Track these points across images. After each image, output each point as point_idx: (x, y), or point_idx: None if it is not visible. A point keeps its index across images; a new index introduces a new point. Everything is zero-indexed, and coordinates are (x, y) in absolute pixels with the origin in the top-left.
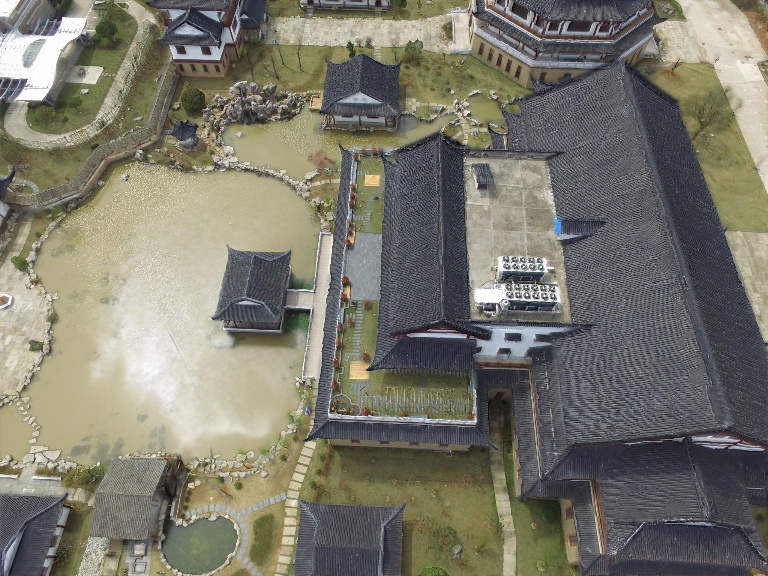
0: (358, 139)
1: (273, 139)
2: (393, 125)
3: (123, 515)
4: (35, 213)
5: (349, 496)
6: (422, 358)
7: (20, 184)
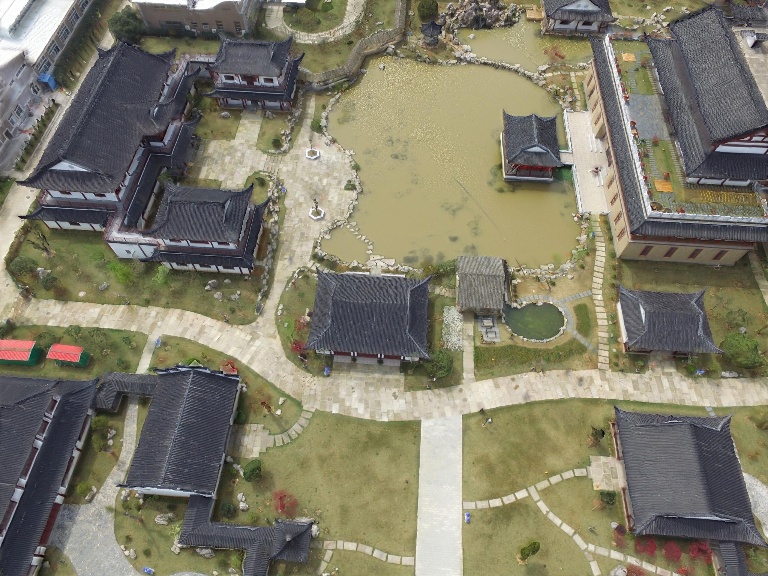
0: (575, 42)
1: (500, 41)
2: (604, 31)
3: (482, 290)
4: (316, 91)
5: None
6: (727, 169)
7: (298, 69)
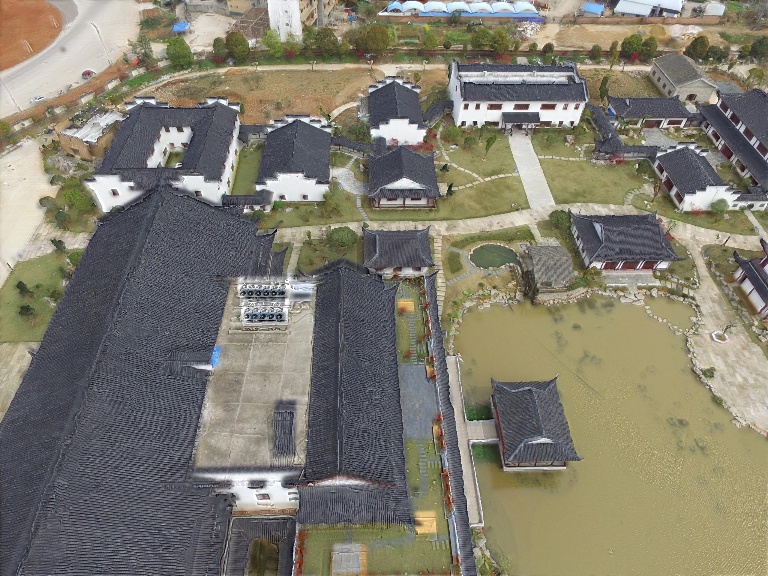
0: None
1: None
2: None
3: None
4: None
5: None
6: None
7: None
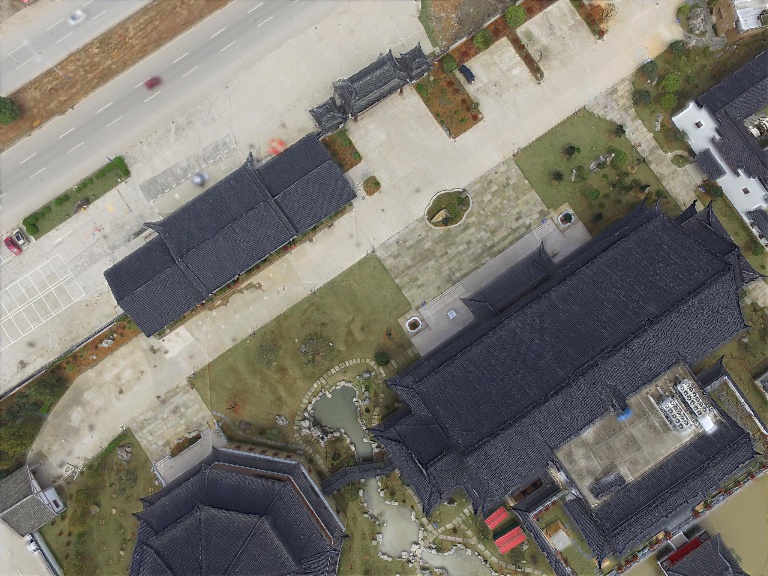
0: None
1: None
2: None
3: None
4: None
5: (762, 412)
6: None
7: None
